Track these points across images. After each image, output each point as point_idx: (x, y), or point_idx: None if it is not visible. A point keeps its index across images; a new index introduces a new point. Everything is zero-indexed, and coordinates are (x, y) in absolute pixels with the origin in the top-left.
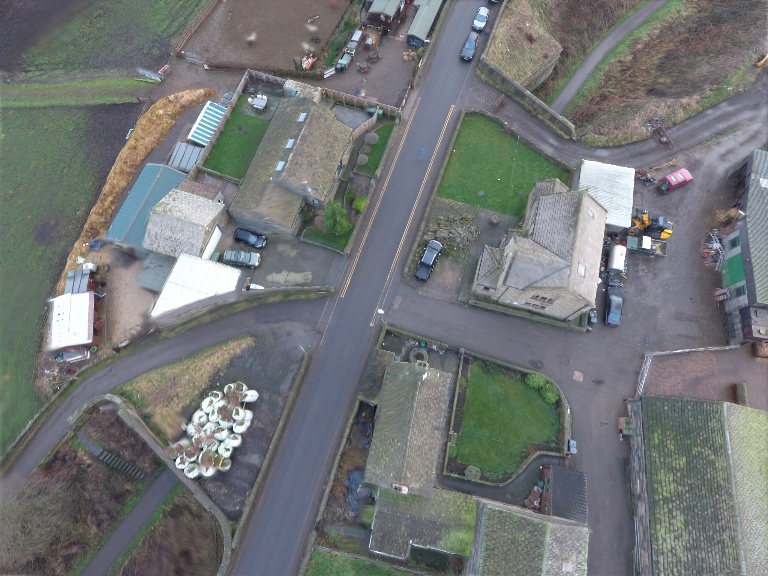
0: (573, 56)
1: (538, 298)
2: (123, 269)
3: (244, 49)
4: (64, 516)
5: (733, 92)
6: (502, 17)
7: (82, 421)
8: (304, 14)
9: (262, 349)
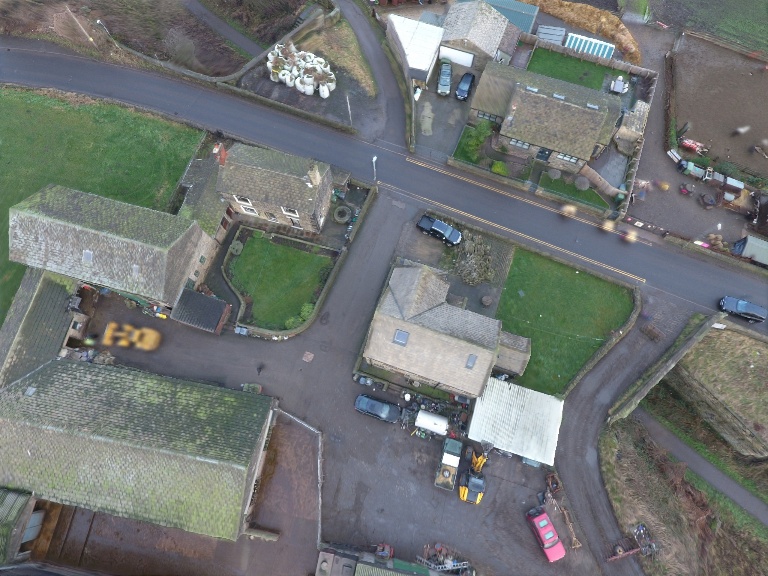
0: None
1: None
2: (443, 12)
3: (702, 88)
4: (263, 4)
5: None
6: None
7: (324, 3)
8: (767, 143)
9: (363, 100)
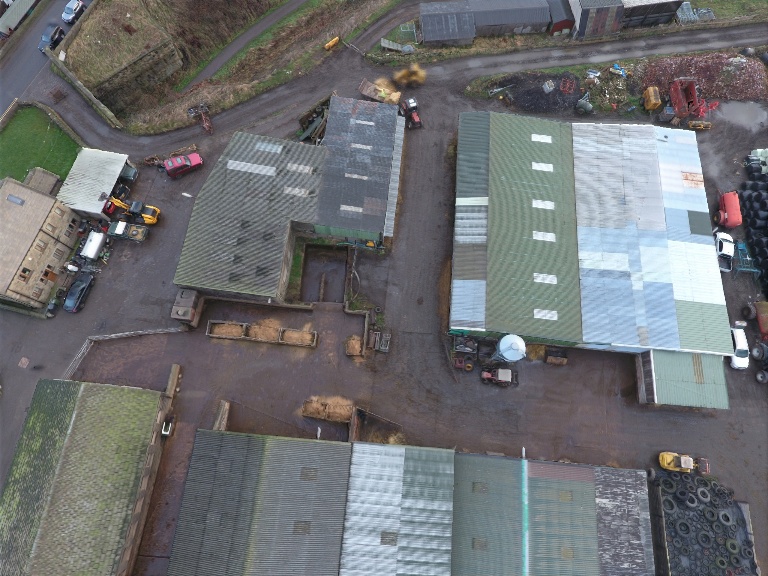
0: (208, 46)
1: None
2: None
3: None
4: None
5: (292, 76)
6: (97, 9)
7: None
8: None
9: None
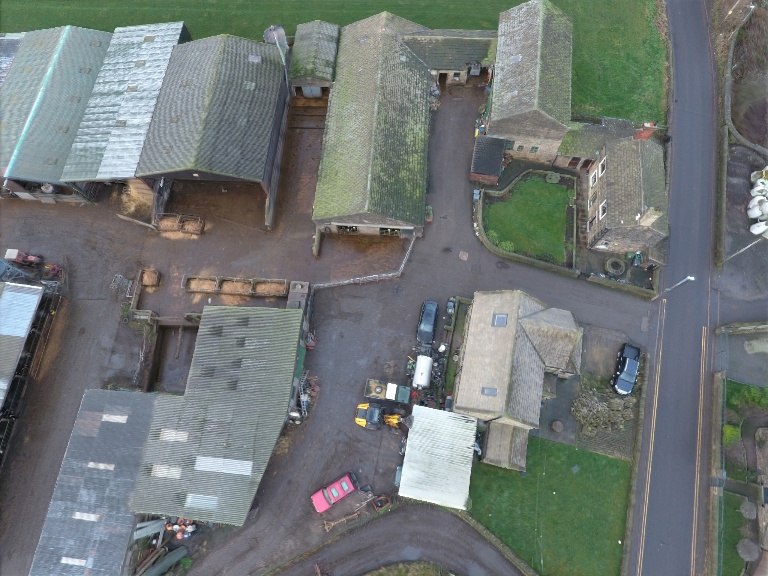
0: None
1: None
2: None
3: None
4: None
5: None
6: None
7: None
8: None
9: (764, 271)
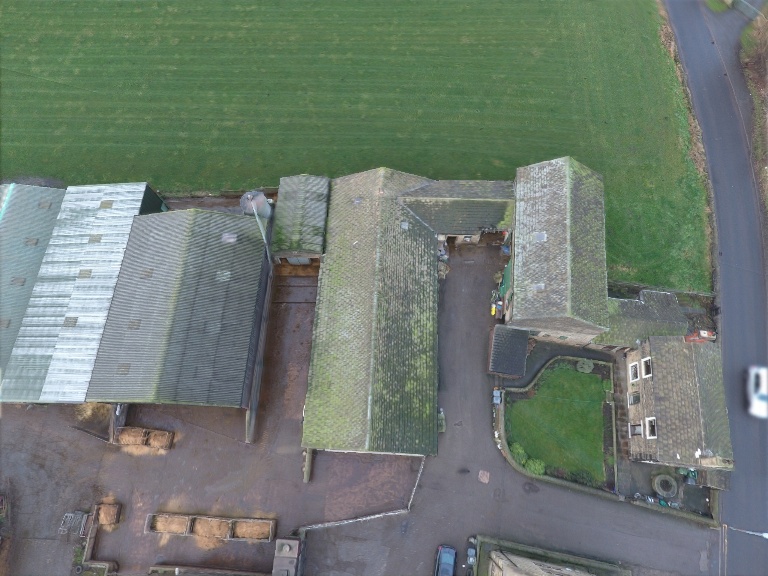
0: None
1: (563, 575)
2: None
3: None
4: None
5: None
6: None
7: None
8: None
9: None
